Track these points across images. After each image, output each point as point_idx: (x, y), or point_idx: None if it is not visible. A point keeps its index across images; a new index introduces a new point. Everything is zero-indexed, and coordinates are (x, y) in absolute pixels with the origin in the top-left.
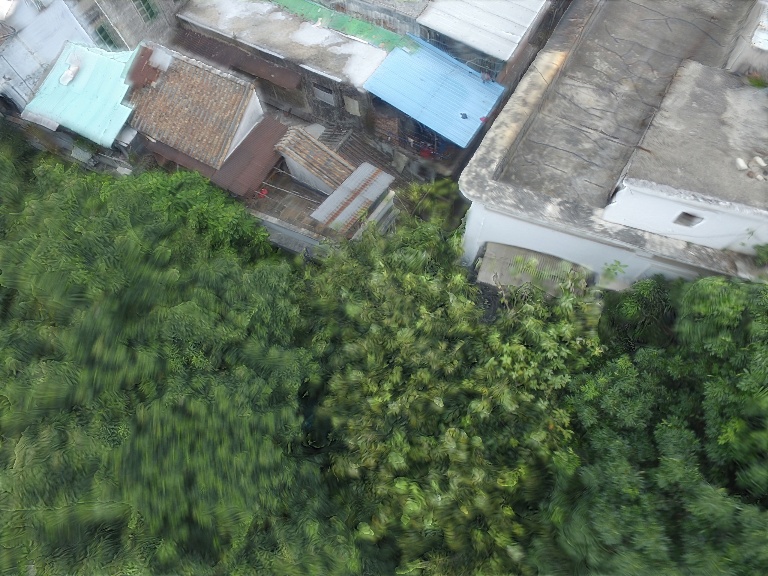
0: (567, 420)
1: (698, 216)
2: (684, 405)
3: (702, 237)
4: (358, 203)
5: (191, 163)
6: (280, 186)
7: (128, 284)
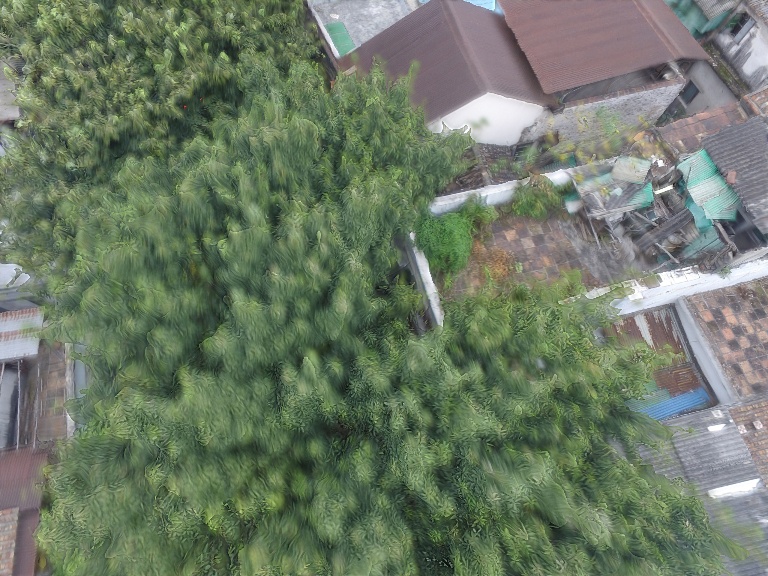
0: None
1: None
2: None
3: None
4: (1, 326)
5: (25, 563)
6: None
7: None
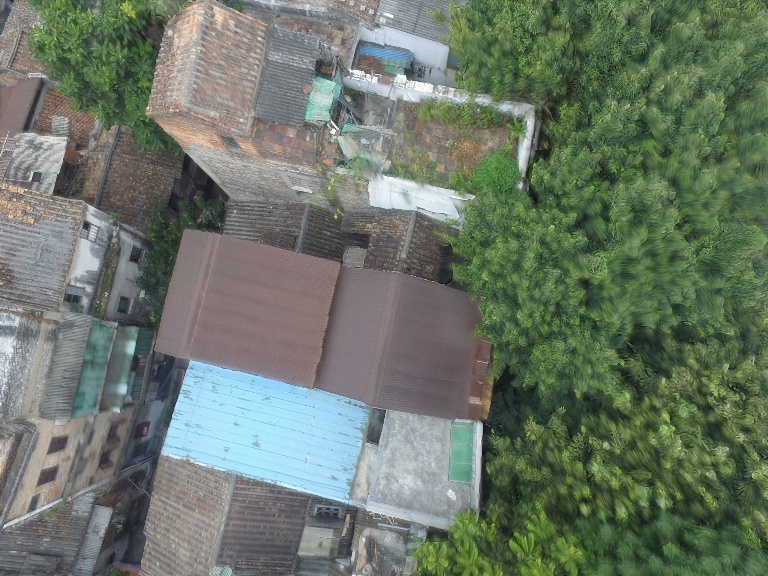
0: None
1: None
2: None
3: None
4: None
5: None
6: None
7: (760, 186)
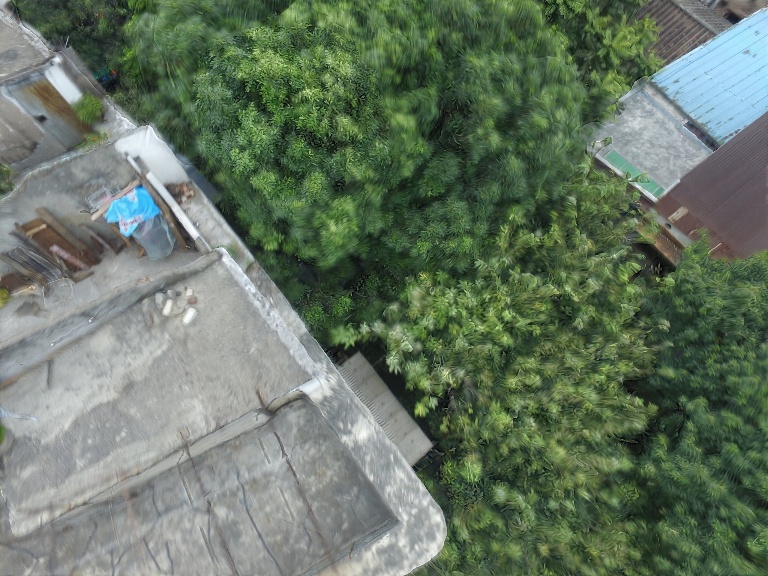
0: None
1: None
2: (398, 200)
3: None
4: None
5: None
6: None
7: None
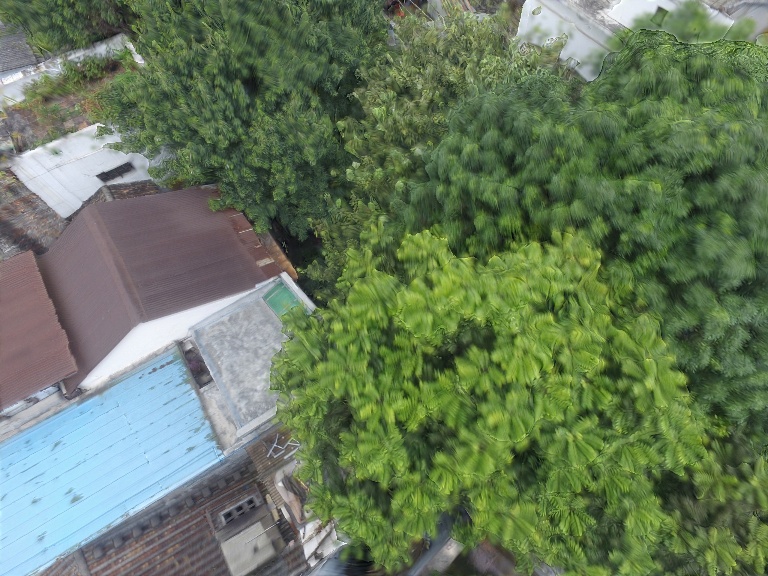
0: (495, 83)
1: (665, 9)
2: None
3: None
4: None
5: None
6: None
7: None
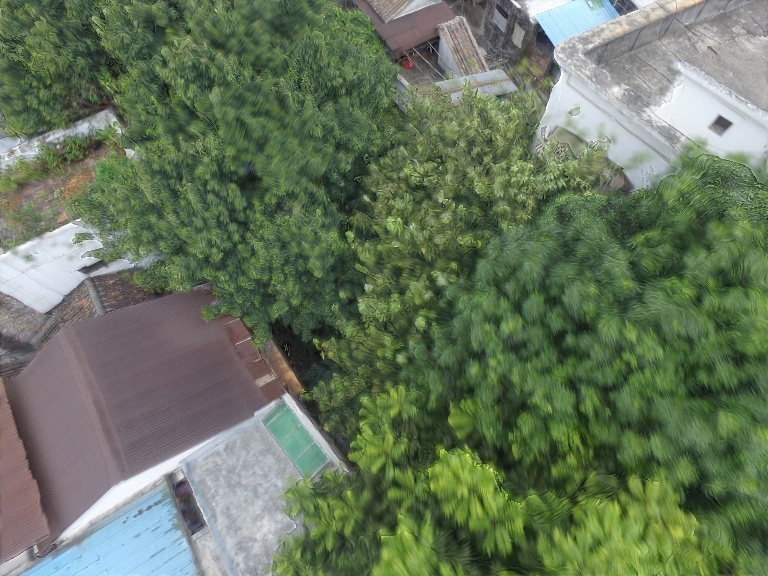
0: (531, 206)
1: (729, 120)
2: None
3: (728, 152)
4: None
5: (369, 12)
6: (425, 67)
7: (289, 11)
